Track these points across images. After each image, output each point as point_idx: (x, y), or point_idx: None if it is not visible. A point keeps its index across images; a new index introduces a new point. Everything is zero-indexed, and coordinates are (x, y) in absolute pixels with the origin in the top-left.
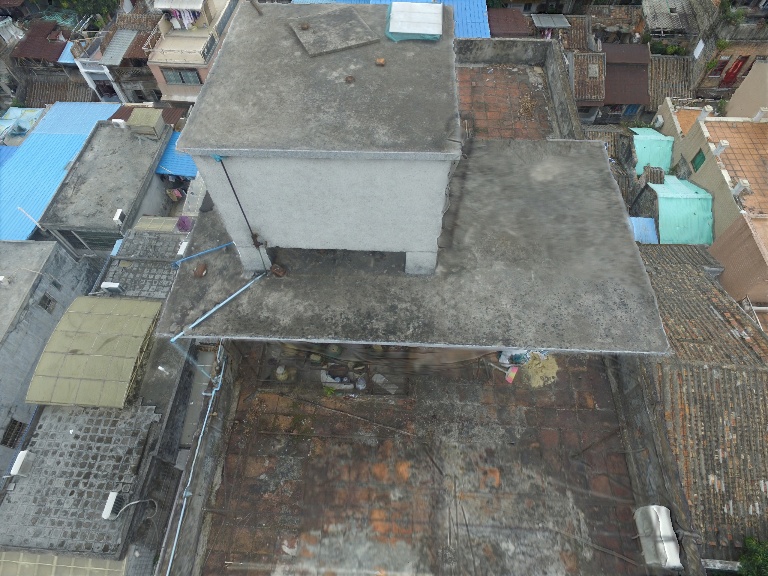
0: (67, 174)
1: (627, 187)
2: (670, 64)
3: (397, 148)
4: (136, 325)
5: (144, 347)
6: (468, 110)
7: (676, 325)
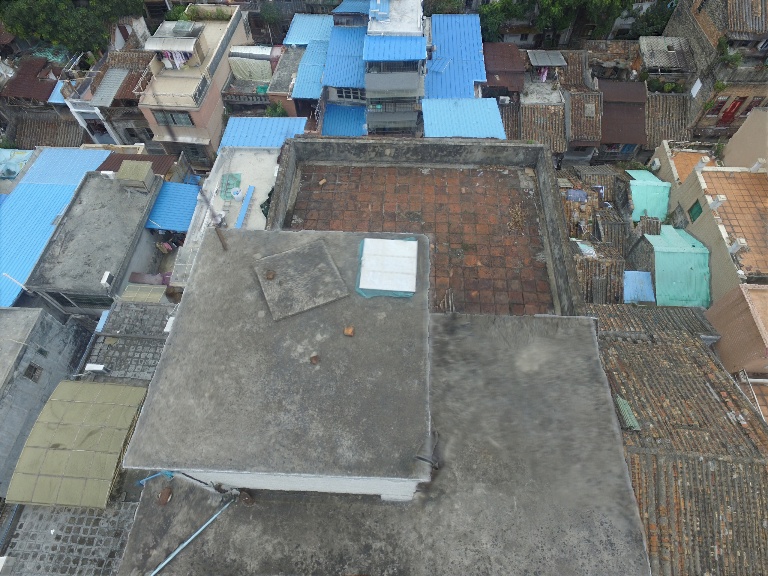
0: (55, 231)
1: (623, 234)
2: (667, 102)
3: (361, 471)
4: (120, 415)
5: (128, 439)
6: (457, 222)
7: (671, 407)
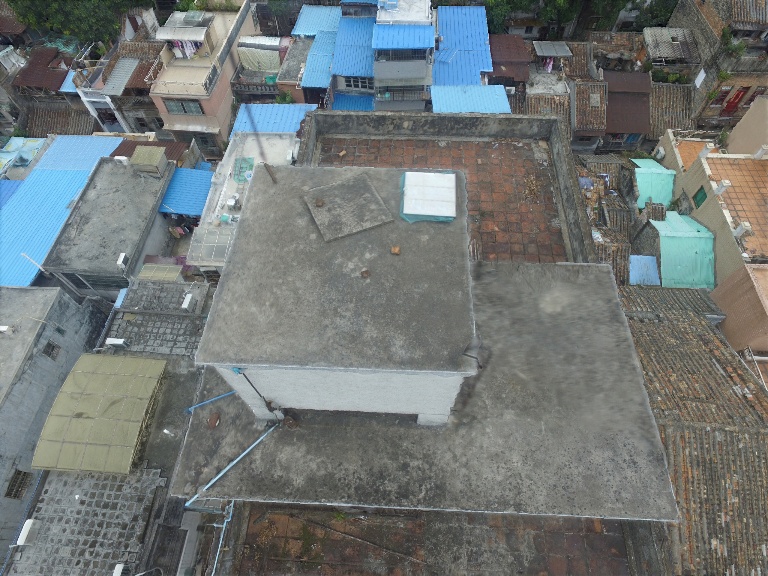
0: (70, 214)
1: (629, 221)
2: (671, 92)
3: (414, 365)
4: (141, 386)
5: (149, 409)
6: (474, 191)
7: (678, 381)
